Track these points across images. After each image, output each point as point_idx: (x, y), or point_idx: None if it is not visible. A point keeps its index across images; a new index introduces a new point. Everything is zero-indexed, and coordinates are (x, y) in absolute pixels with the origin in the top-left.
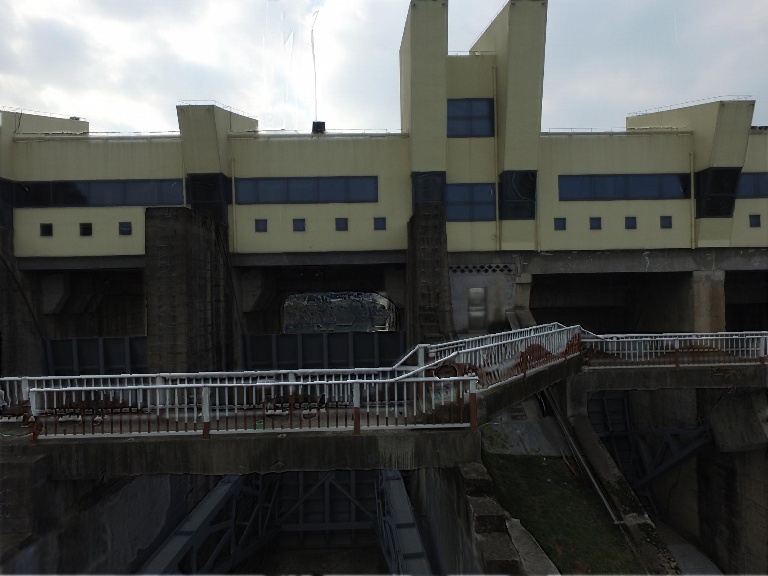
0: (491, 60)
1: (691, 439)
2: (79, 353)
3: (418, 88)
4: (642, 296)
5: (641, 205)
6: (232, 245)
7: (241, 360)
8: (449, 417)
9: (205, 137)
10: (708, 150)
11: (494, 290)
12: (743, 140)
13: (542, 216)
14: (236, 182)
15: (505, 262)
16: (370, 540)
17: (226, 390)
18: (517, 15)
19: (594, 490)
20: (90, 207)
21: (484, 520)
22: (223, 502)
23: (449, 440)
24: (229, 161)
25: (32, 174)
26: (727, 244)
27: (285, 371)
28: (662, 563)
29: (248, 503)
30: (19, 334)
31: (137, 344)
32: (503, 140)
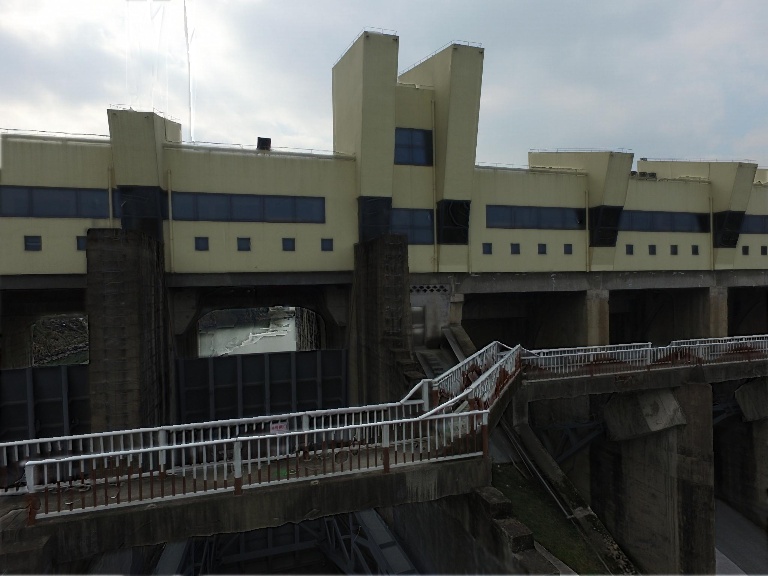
0: (430, 94)
1: (587, 432)
2: None
3: (368, 116)
4: (542, 309)
5: (550, 234)
6: (168, 264)
7: (174, 387)
8: (464, 448)
9: (141, 147)
10: (600, 191)
11: (432, 309)
12: (625, 185)
13: (473, 241)
14: (173, 196)
15: (441, 283)
16: (313, 558)
17: (258, 443)
18: (458, 59)
19: (546, 491)
20: None
21: (519, 541)
22: (187, 548)
23: (466, 469)
24: (165, 173)
25: None
26: (611, 268)
27: (298, 414)
28: (608, 547)
29: (198, 542)
30: None
31: (42, 375)
32: (443, 171)
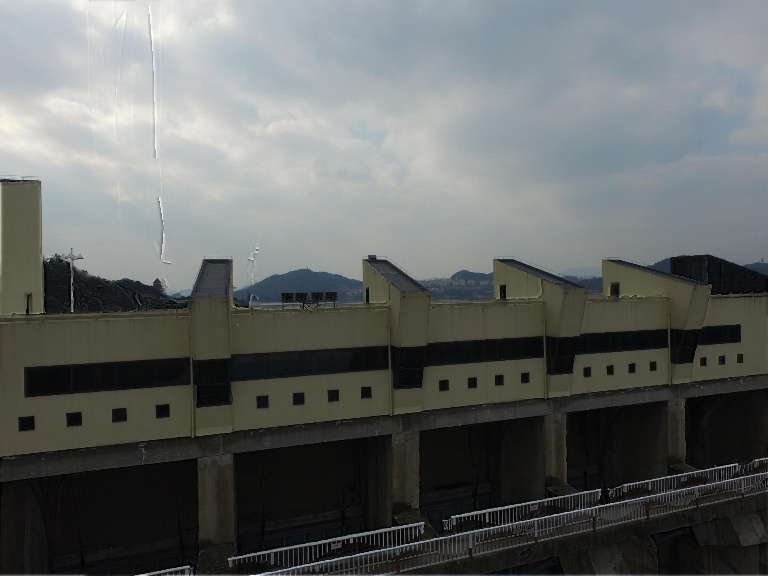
0: None
1: None
2: None
3: None
4: None
5: (133, 394)
6: None
7: None
8: None
9: None
10: None
11: None
12: (224, 333)
13: (1, 416)
14: None
15: None
16: None
17: None
18: None
19: None
20: None
21: None
22: None
23: None
24: None
25: None
26: (229, 430)
27: None
28: None
29: None
30: None
31: None
32: None
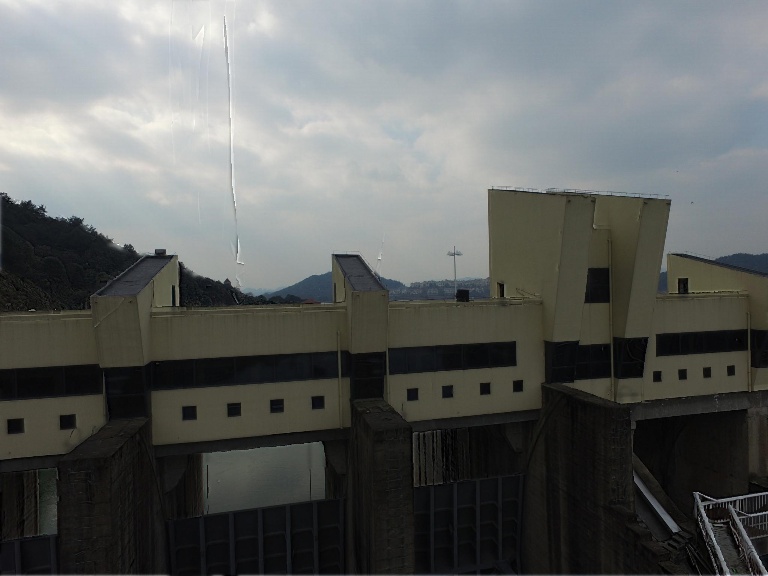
0: (606, 234)
1: None
2: (206, 531)
3: (564, 270)
4: None
5: (714, 357)
6: None
7: None
8: None
9: (376, 320)
10: (766, 316)
11: None
12: None
13: (644, 370)
14: (389, 353)
15: None
16: None
17: None
18: (647, 212)
19: None
20: (238, 385)
21: None
22: None
23: None
24: None
25: (172, 352)
26: None
27: None
28: None
29: None
30: (155, 529)
31: (269, 514)
32: (624, 312)
